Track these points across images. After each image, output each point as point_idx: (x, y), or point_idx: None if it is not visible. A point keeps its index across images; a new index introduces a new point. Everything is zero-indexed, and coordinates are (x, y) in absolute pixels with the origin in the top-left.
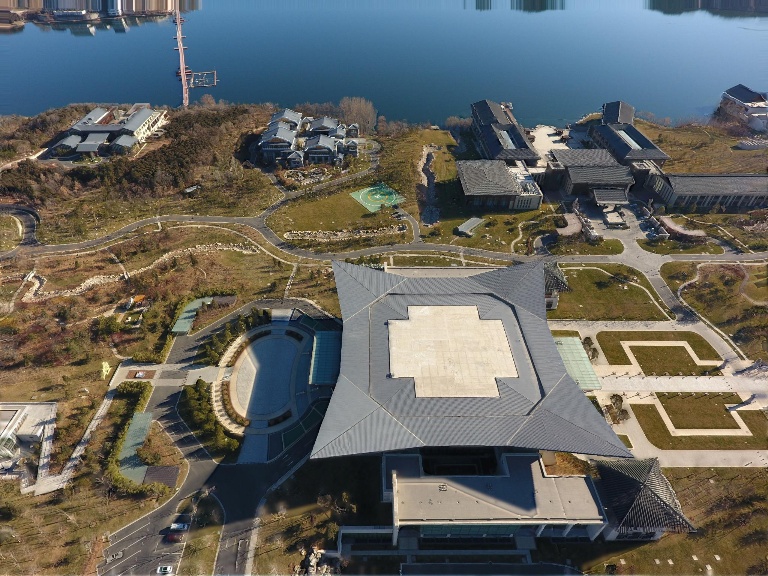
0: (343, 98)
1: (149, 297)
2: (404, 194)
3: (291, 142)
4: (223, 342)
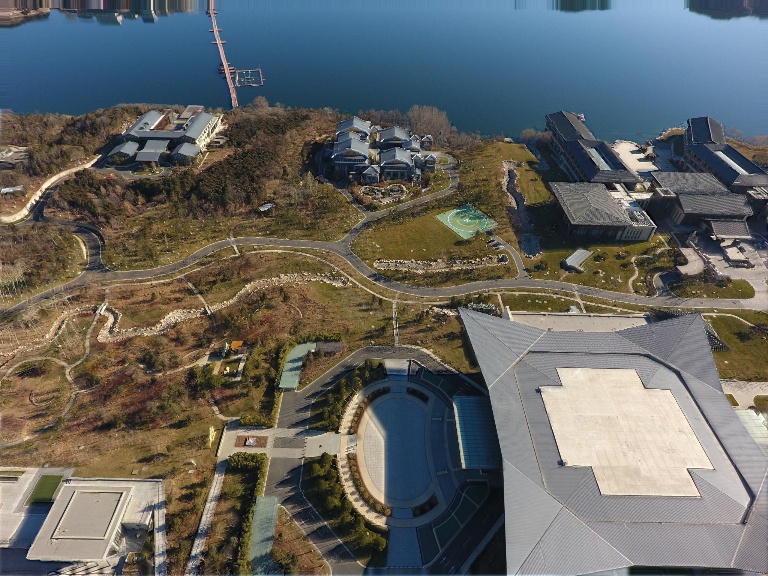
0: (413, 106)
1: (245, 342)
2: (495, 218)
3: (367, 156)
4: (338, 401)
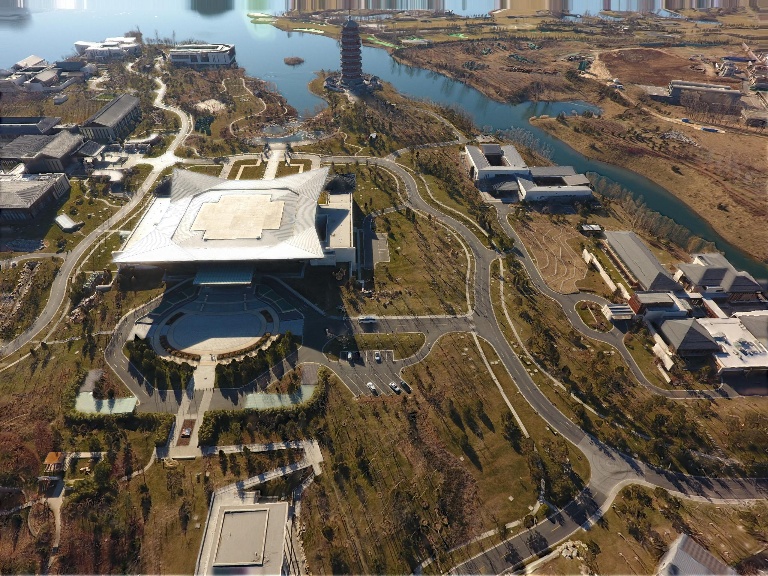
0: None
1: None
2: None
3: None
4: None
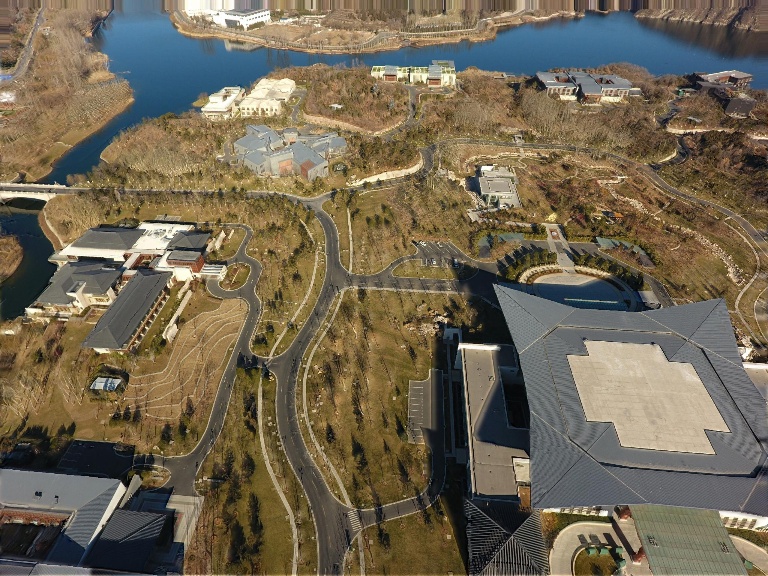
0: None
1: None
2: None
3: None
4: (599, 266)
